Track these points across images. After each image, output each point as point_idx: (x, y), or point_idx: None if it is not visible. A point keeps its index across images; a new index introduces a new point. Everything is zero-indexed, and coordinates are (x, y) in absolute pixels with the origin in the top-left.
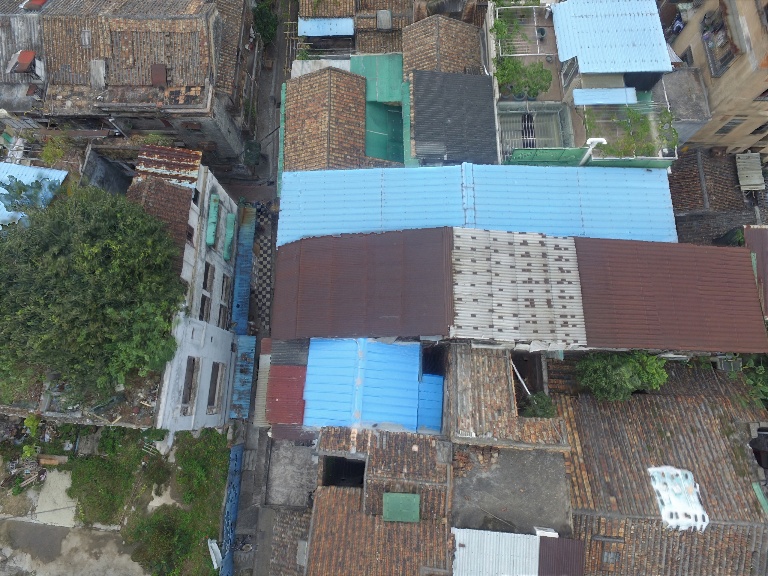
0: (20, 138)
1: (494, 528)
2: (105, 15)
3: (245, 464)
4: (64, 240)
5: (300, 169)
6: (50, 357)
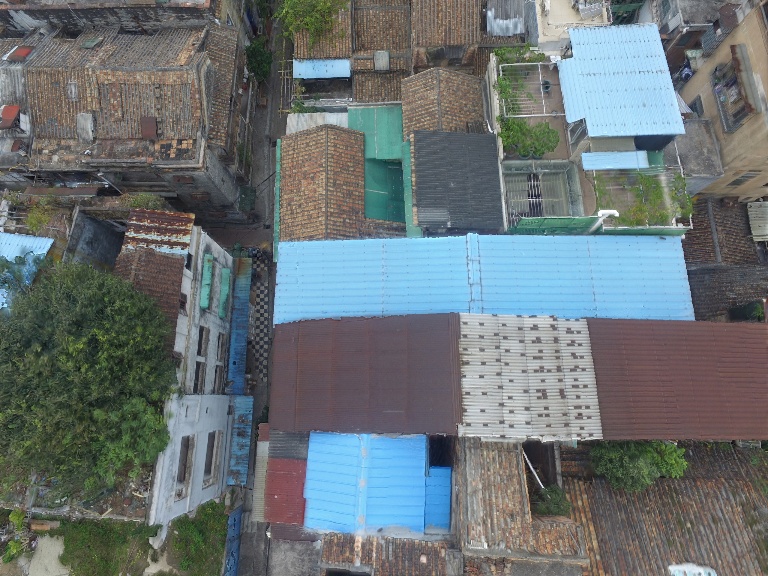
0: (4, 200)
1: None
2: (92, 67)
3: (244, 527)
4: (48, 332)
5: (297, 233)
6: (34, 460)
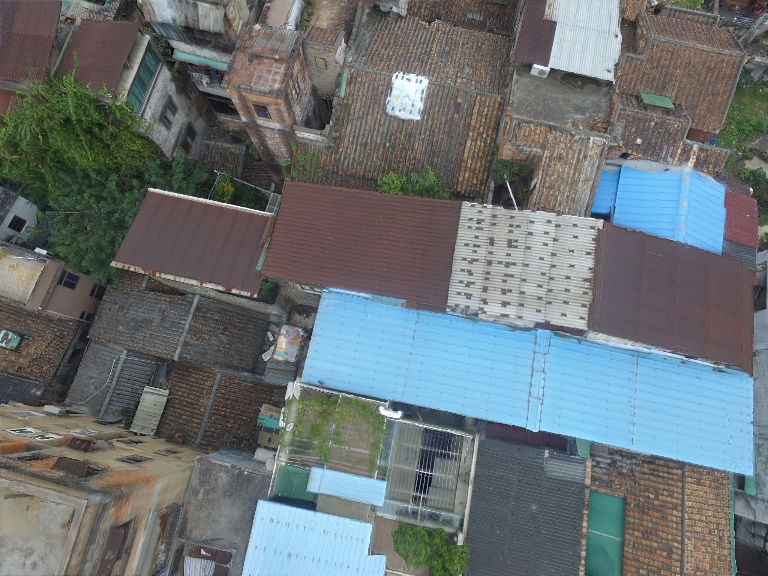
0: None
1: (577, 82)
2: None
3: None
4: None
5: (712, 494)
6: None
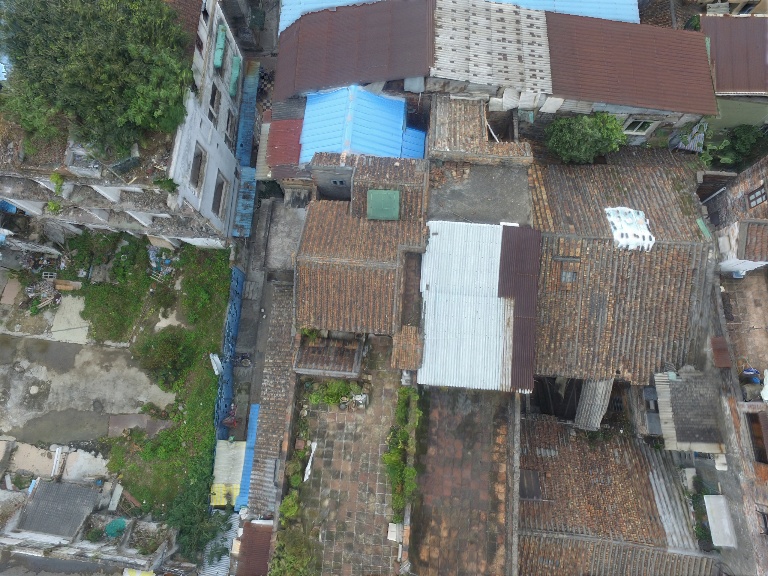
0: None
1: None
2: None
3: (245, 292)
4: None
5: None
6: (76, 94)
